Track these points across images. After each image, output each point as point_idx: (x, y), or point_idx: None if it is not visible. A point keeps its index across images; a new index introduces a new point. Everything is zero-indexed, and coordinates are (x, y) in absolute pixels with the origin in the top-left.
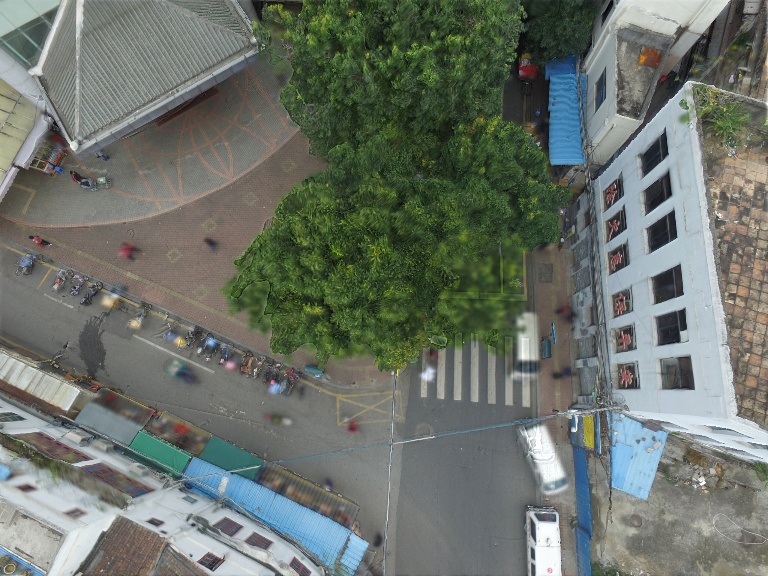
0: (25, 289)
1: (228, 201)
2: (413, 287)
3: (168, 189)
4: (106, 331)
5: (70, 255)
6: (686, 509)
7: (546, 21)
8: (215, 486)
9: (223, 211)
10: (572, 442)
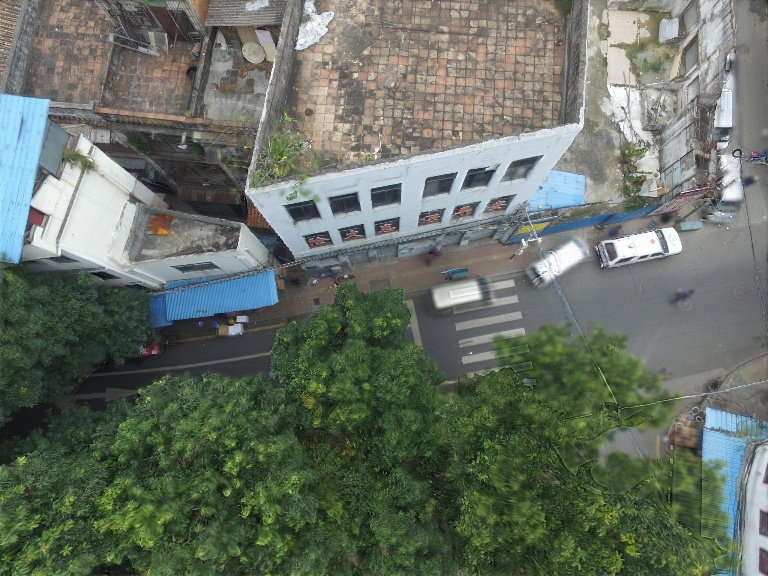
0: None
1: None
2: None
3: None
4: None
5: None
6: None
7: (115, 340)
8: None
9: None
10: None
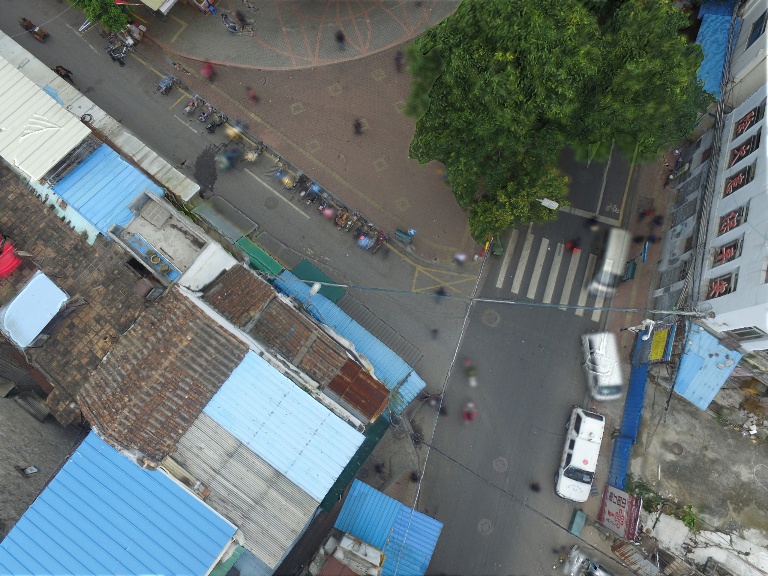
0: (159, 107)
1: (358, 72)
2: (566, 108)
3: (305, 49)
4: (222, 159)
5: (205, 87)
6: (730, 451)
7: None
8: (300, 298)
9: (351, 80)
10: (632, 362)
